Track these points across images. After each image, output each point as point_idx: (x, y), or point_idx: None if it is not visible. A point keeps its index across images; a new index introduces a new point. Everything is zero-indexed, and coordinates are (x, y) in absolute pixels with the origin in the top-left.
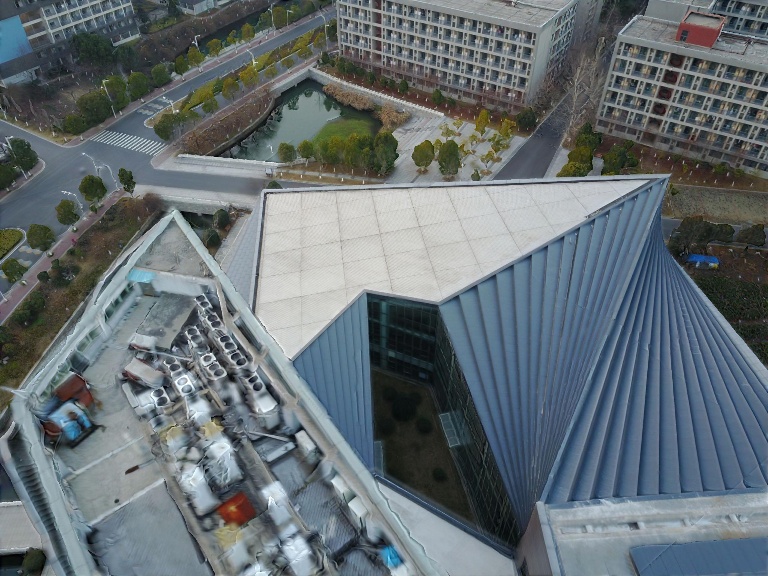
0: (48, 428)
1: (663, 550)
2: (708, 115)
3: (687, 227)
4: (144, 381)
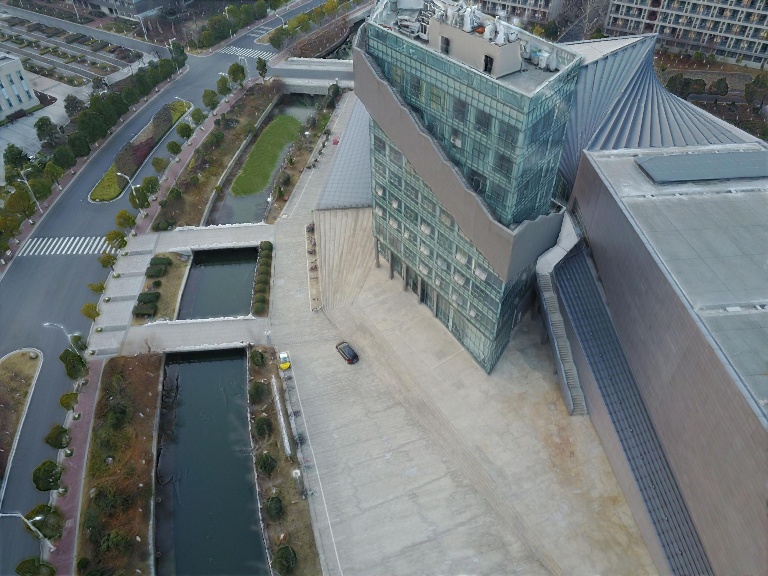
0: None
1: (652, 157)
2: (688, 17)
3: (672, 82)
4: (410, 27)
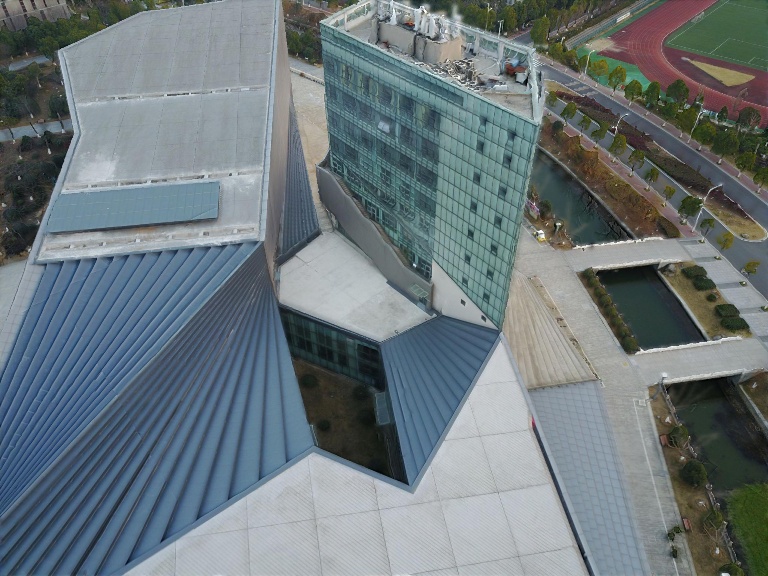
0: (511, 52)
1: (198, 216)
2: None
3: None
4: None
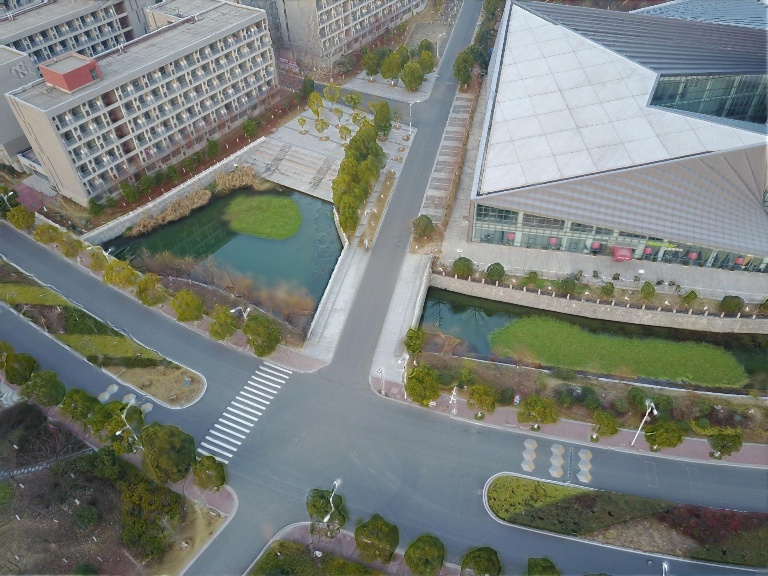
0: None
1: None
2: None
3: (484, 39)
4: None
